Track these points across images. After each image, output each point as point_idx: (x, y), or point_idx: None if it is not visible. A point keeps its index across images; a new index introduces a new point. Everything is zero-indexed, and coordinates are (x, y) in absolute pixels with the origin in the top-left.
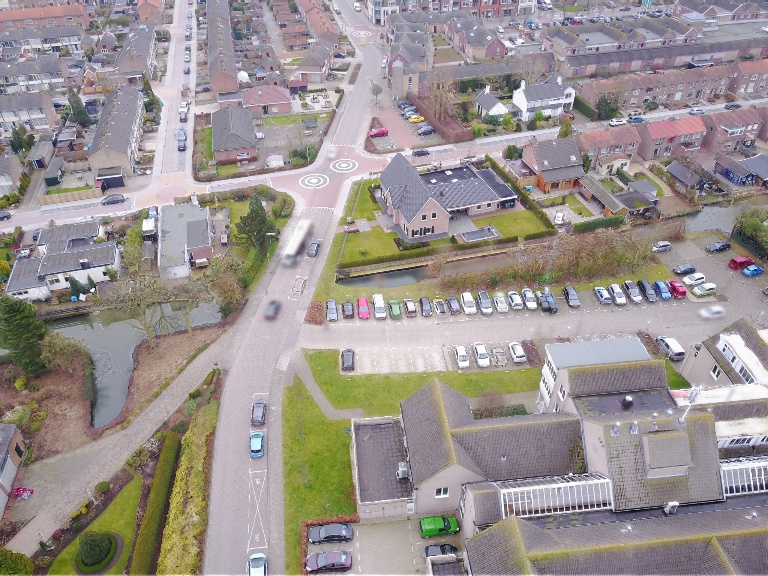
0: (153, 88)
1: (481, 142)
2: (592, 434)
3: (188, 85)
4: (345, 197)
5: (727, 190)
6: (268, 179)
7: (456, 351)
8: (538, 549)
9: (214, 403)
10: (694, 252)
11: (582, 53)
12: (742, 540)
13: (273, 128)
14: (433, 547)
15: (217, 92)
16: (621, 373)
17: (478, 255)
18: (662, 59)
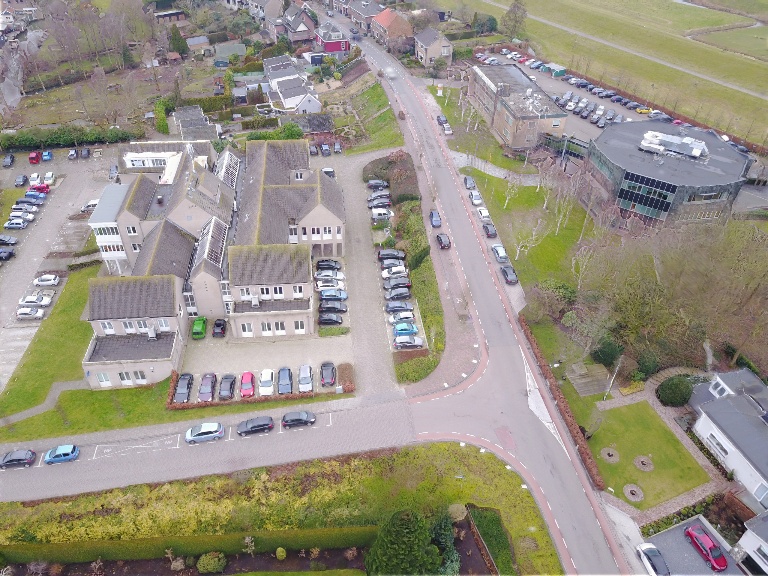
0: None
1: None
2: (181, 213)
3: None
4: None
5: None
6: None
7: (22, 314)
8: (252, 243)
9: None
10: (3, 173)
11: None
12: (266, 180)
13: None
14: (215, 328)
15: None
16: (140, 192)
17: None
18: None
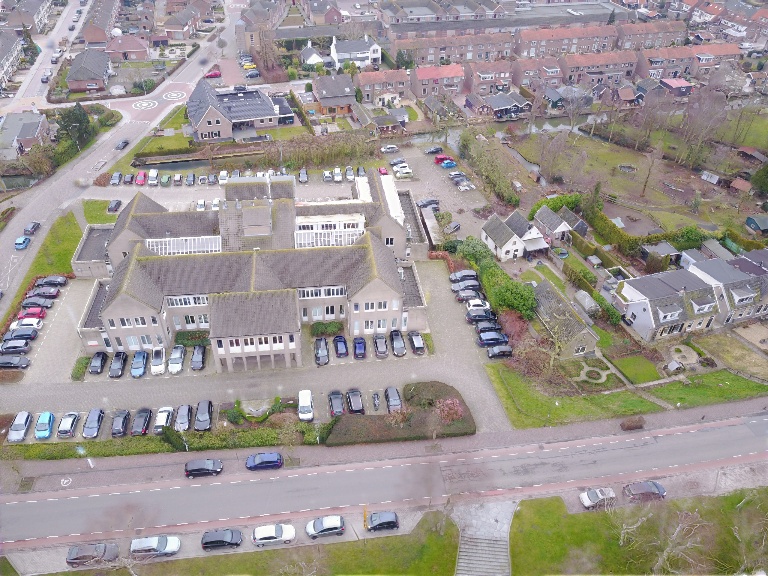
0: (38, 39)
1: (294, 83)
2: None
3: (67, 37)
4: (164, 115)
5: (465, 117)
6: (108, 103)
7: None
8: None
9: (2, 223)
10: (415, 154)
11: (404, 22)
12: (273, 254)
13: (128, 69)
14: None
15: (88, 42)
16: (262, 188)
17: (251, 153)
18: (473, 30)
